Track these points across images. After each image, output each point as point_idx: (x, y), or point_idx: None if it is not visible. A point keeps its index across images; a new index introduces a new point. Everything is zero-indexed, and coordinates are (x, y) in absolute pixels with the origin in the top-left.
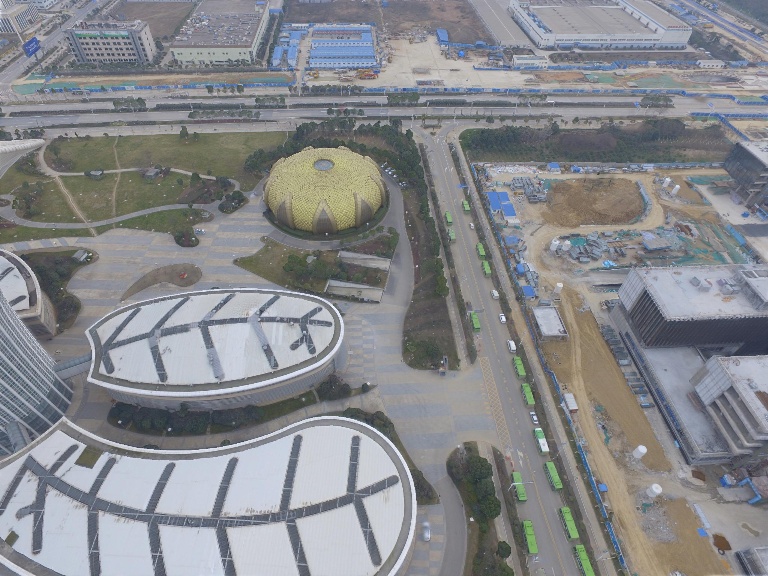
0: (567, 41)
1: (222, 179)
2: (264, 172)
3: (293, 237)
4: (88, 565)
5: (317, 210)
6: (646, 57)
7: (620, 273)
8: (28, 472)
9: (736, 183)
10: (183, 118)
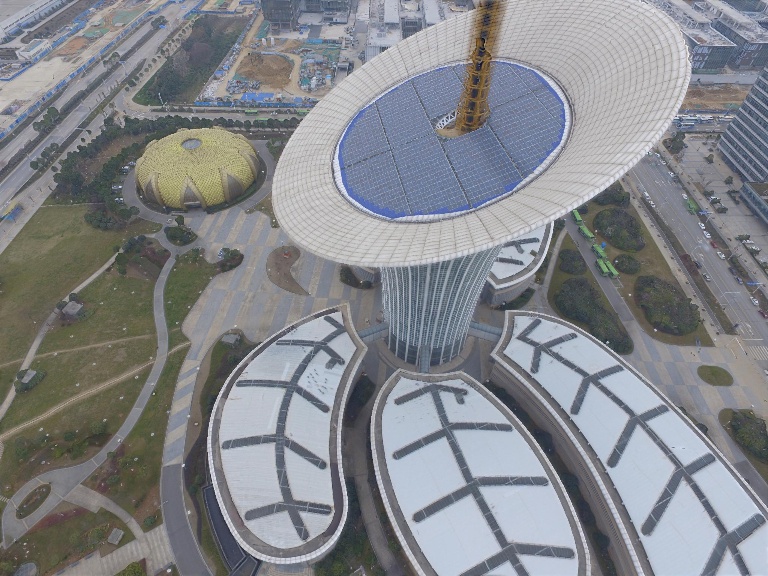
0: (11, 26)
1: (132, 242)
2: None
3: (253, 195)
4: None
5: (249, 158)
6: (78, 9)
7: (336, 76)
8: None
9: (273, 26)
10: None
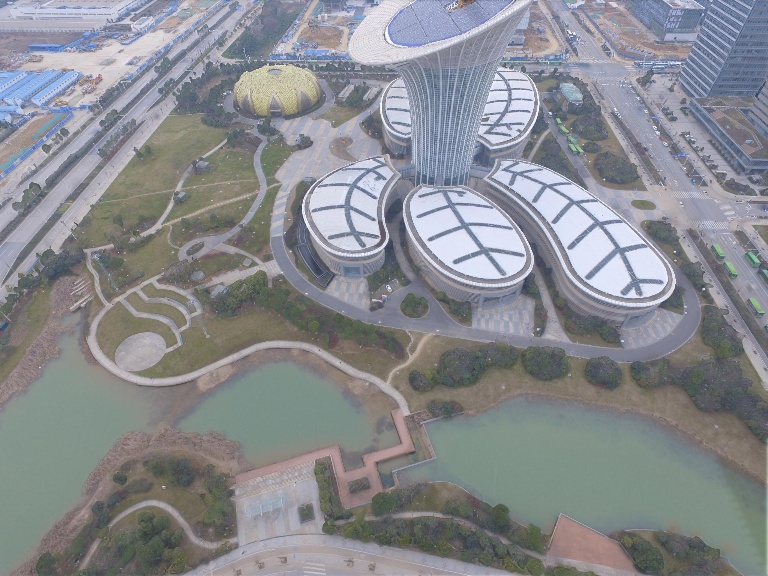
0: (122, 9)
1: (236, 132)
2: (231, 122)
3: (318, 110)
4: (527, 113)
5: (315, 83)
6: None
7: None
8: (492, 131)
9: None
10: (90, 168)
